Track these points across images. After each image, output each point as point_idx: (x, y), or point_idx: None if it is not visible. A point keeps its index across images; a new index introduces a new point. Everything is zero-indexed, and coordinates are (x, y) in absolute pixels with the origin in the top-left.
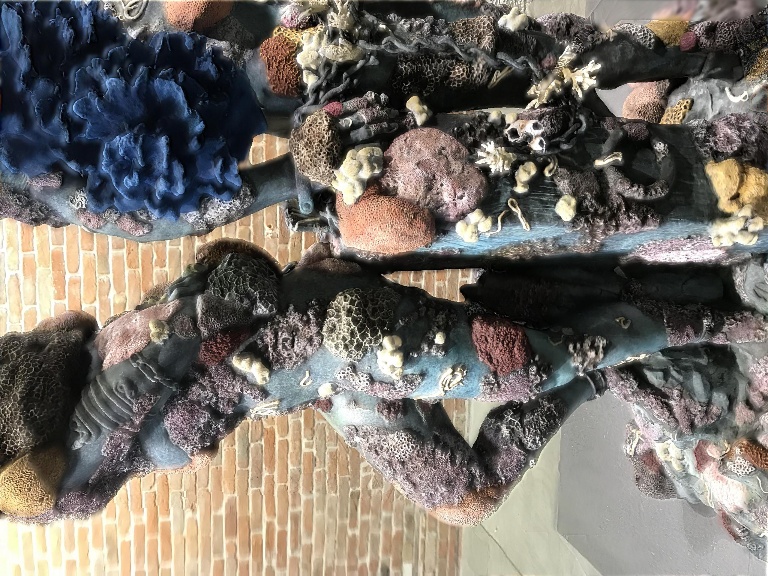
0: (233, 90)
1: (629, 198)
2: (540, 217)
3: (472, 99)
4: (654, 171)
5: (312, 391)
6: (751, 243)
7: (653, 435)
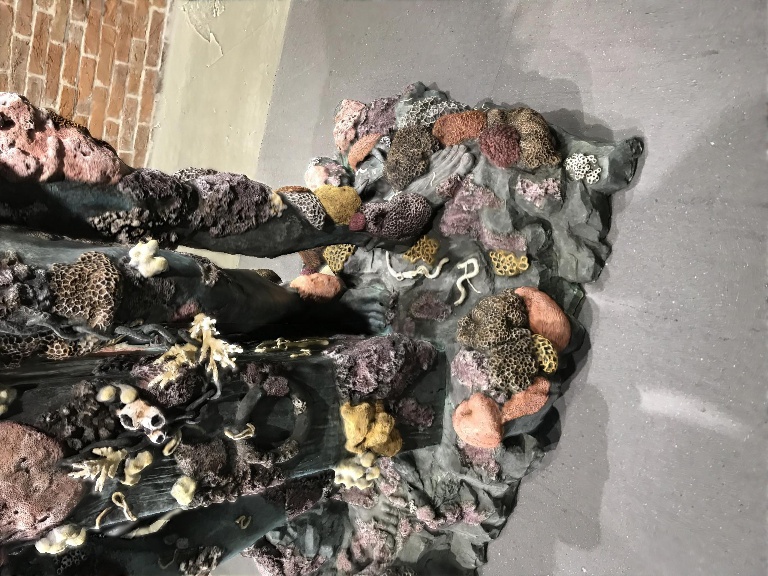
0: None
1: (257, 463)
2: (151, 505)
3: None
4: (289, 422)
5: None
6: None
7: (264, 574)
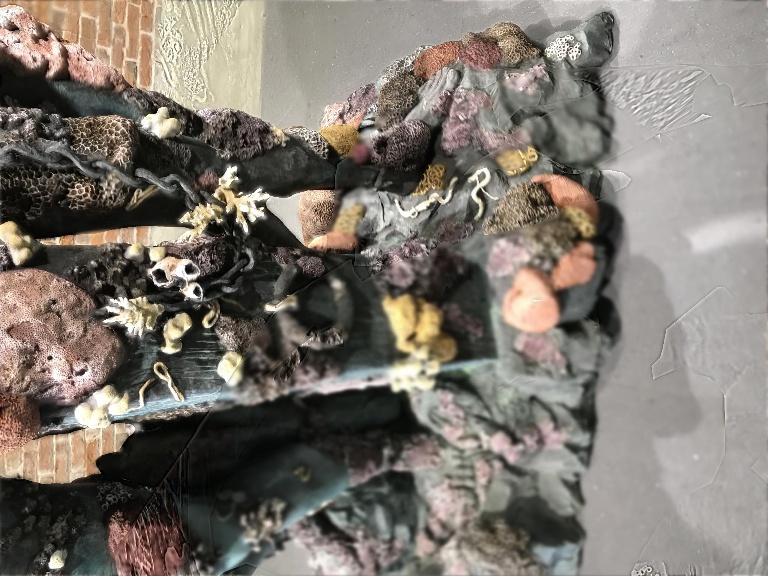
0: None
1: None
2: (198, 383)
3: (104, 222)
4: None
5: None
6: None
7: None
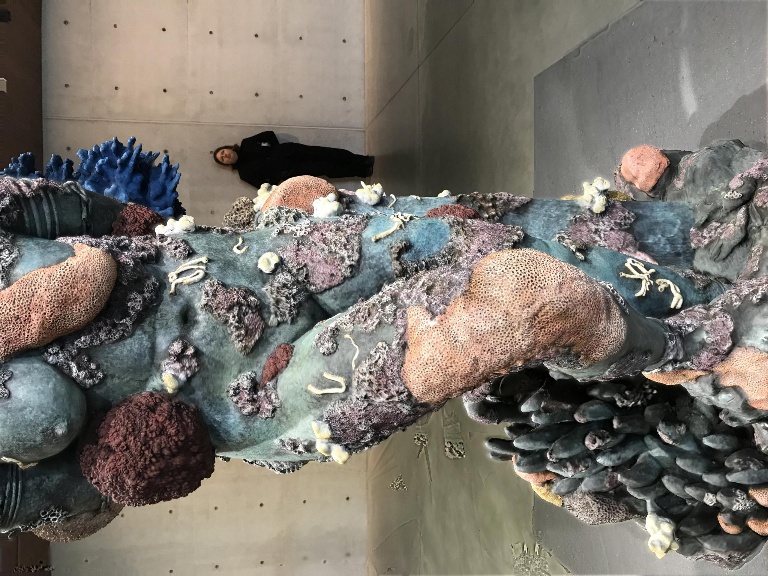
0: (182, 213)
1: None
2: None
3: None
4: None
5: (251, 270)
6: (607, 183)
7: None
